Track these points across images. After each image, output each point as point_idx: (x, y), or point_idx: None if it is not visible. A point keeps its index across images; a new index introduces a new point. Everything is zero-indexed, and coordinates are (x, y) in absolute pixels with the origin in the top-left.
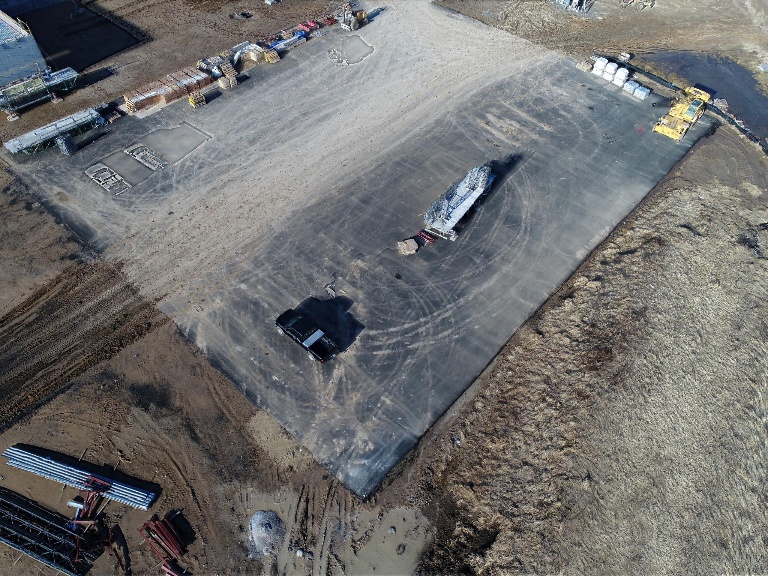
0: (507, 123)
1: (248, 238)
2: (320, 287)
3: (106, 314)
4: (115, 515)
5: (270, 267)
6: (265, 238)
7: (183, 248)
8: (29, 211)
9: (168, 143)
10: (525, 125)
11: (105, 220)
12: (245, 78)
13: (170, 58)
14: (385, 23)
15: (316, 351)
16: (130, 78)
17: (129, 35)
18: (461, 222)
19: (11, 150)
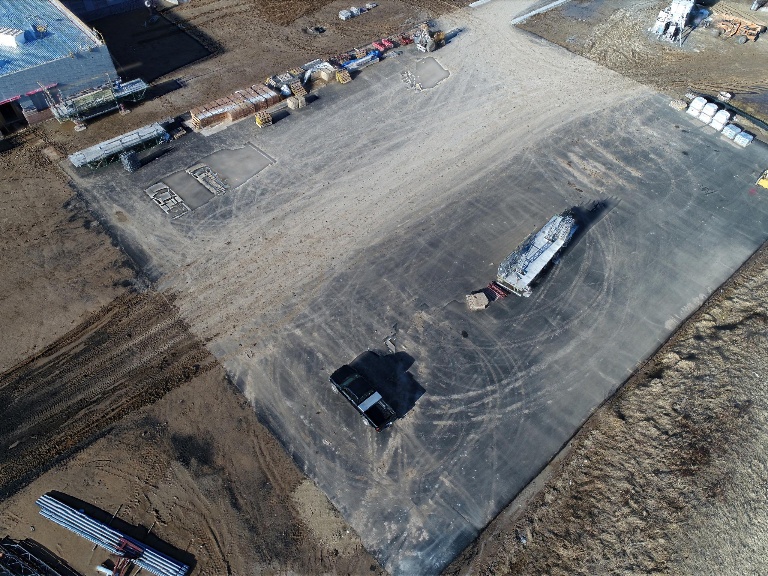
0: (591, 165)
1: (306, 277)
2: (379, 340)
3: (154, 351)
4: None
5: (327, 312)
6: (324, 278)
7: (238, 283)
8: (87, 230)
9: (231, 165)
10: (611, 168)
11: (161, 245)
12: (314, 98)
13: (240, 73)
14: (463, 45)
15: (372, 416)
16: (198, 92)
17: (201, 46)
18: None
19: (75, 164)
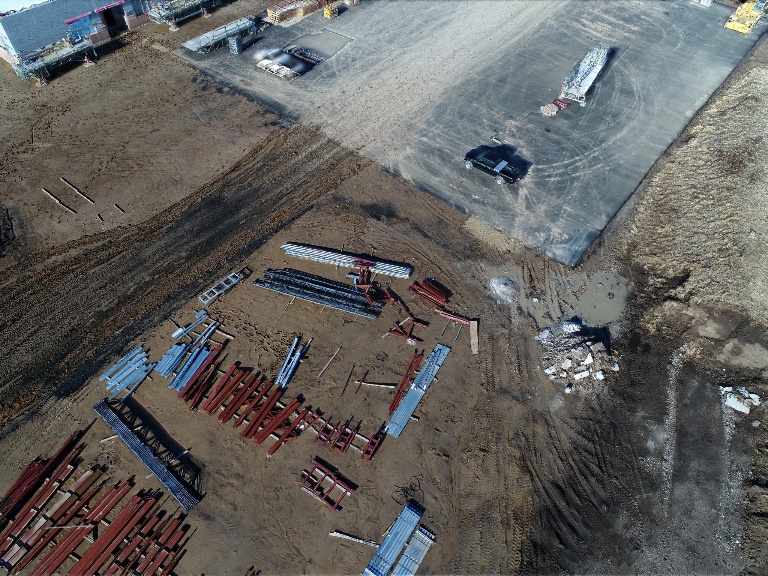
0: (600, 25)
1: (415, 107)
2: (487, 138)
3: (320, 160)
4: (384, 282)
5: (441, 126)
6: (429, 107)
7: (364, 115)
8: (222, 94)
9: (318, 44)
10: (615, 26)
11: (290, 98)
12: None
13: None
14: None
15: None
16: None
17: None
18: (585, 94)
19: (191, 48)
